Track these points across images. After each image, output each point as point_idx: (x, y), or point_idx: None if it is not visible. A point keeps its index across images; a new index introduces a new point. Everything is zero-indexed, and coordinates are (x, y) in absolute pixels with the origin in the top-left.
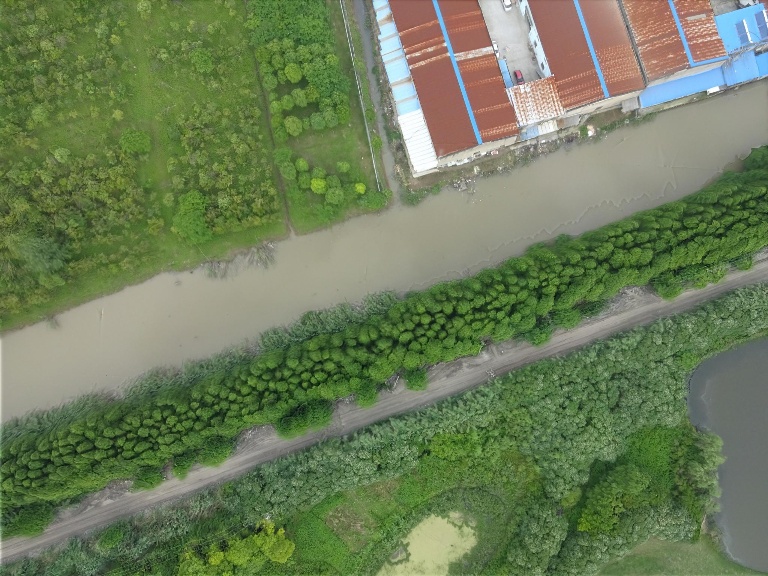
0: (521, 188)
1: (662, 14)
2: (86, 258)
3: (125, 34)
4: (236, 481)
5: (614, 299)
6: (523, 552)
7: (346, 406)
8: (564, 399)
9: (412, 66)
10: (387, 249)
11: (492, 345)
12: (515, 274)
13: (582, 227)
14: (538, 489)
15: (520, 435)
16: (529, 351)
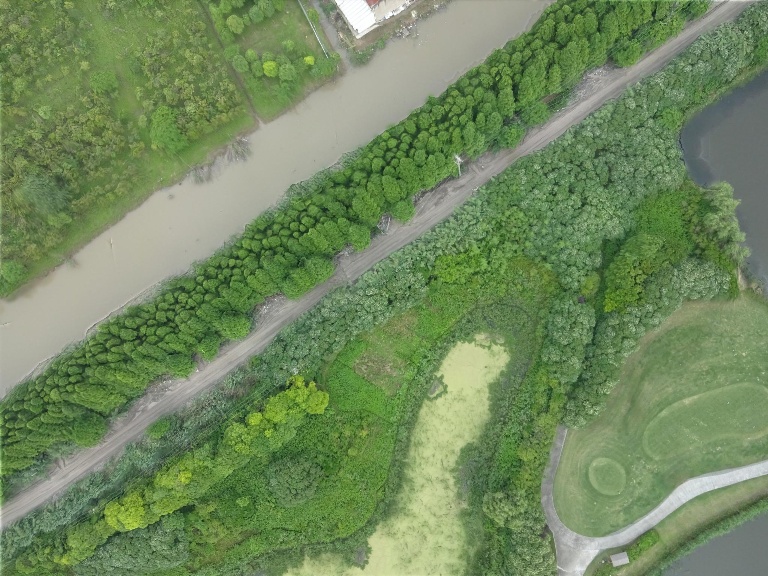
0: (462, 18)
1: None
2: (85, 194)
3: None
4: (261, 352)
5: (580, 87)
6: (555, 347)
7: (347, 259)
8: (552, 186)
9: None
10: (350, 111)
11: (471, 164)
12: None
13: None
14: (556, 288)
15: (520, 237)
16: (509, 159)
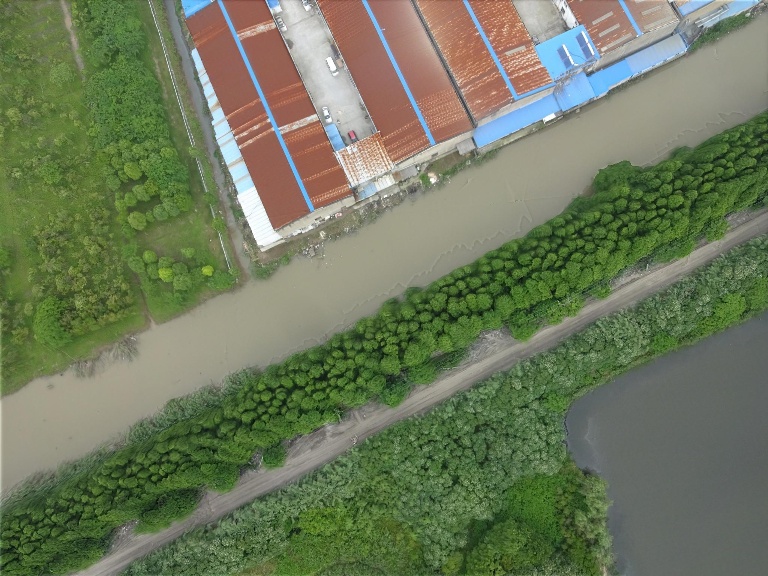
0: (371, 245)
1: (479, 54)
2: None
3: None
4: None
5: (475, 346)
6: None
7: (214, 491)
8: (425, 460)
9: (241, 146)
10: (244, 326)
11: (354, 410)
12: (354, 337)
13: (436, 276)
14: (420, 557)
15: (389, 502)
16: (392, 412)
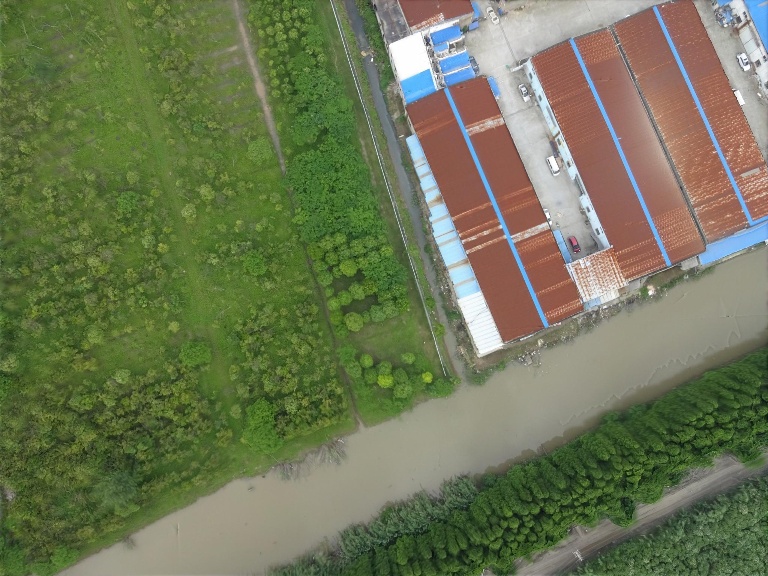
0: (586, 355)
1: (716, 173)
2: (158, 478)
3: (172, 240)
4: None
5: (692, 464)
6: None
7: None
8: None
9: (469, 251)
10: (458, 432)
11: None
12: (597, 464)
13: (652, 390)
14: None
15: None
16: (613, 527)
